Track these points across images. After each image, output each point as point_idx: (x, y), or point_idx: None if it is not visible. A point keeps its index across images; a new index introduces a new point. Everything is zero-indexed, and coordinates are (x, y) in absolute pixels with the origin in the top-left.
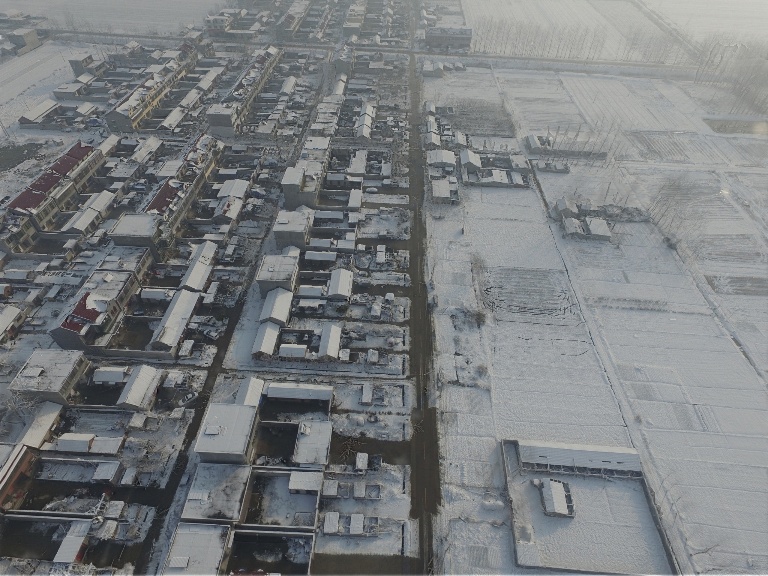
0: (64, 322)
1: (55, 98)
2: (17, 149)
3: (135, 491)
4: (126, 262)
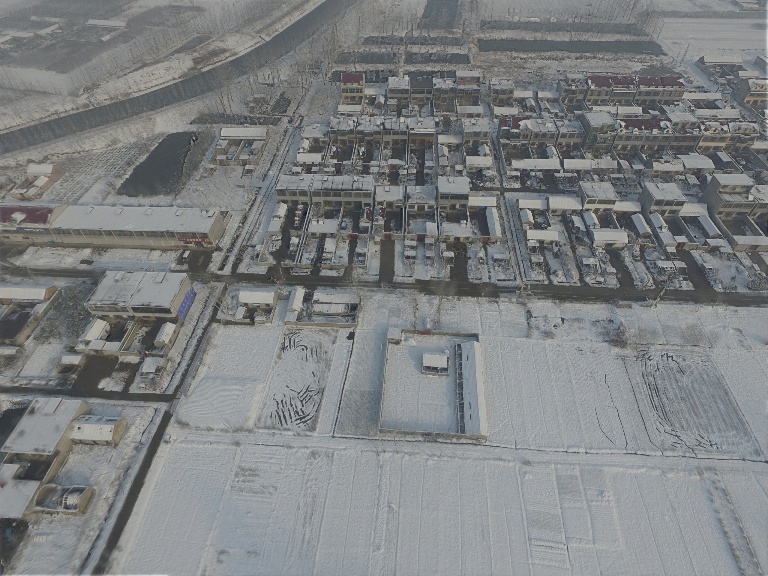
0: (506, 118)
1: (754, 62)
2: (668, 71)
3: (422, 177)
4: (566, 128)
